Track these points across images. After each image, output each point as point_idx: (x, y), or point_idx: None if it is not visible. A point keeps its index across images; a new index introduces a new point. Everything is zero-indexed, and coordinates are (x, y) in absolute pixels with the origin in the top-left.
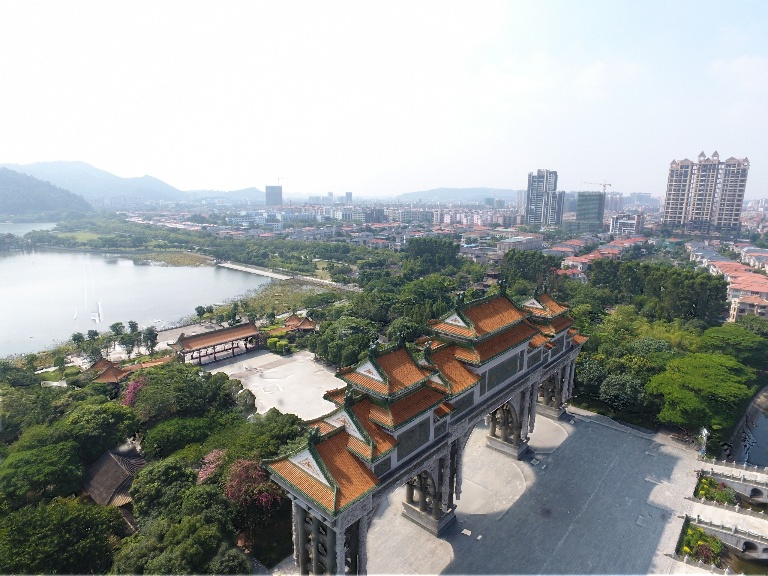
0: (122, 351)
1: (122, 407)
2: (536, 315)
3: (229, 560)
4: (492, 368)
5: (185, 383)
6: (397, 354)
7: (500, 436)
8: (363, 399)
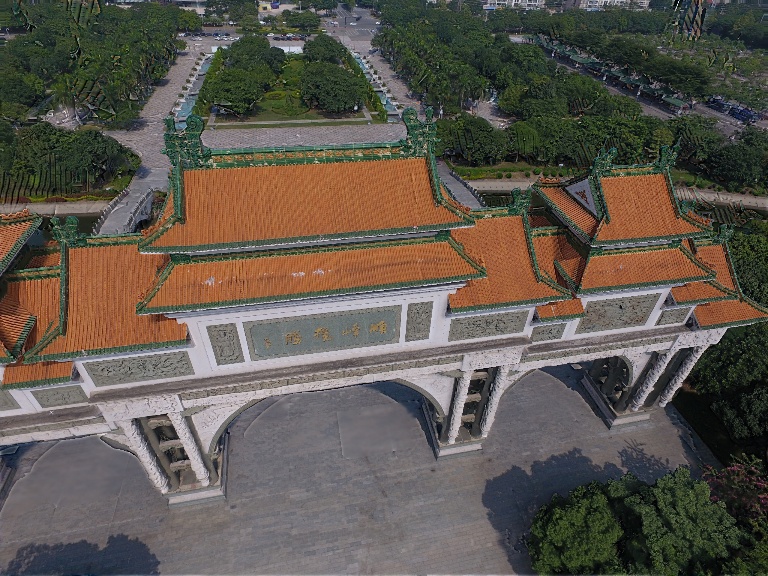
0: None
1: None
2: (22, 246)
3: (760, 396)
4: None
5: None
6: None
7: None
8: None
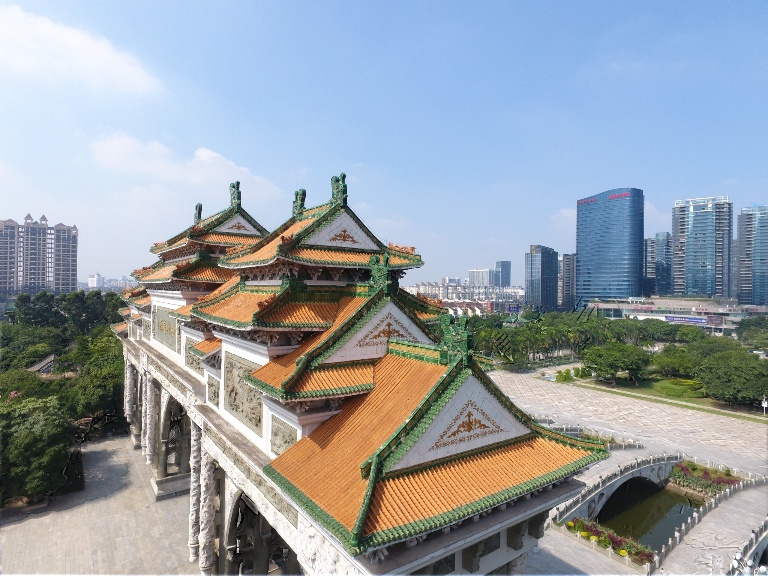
0: None
1: None
2: None
3: None
4: None
5: None
6: None
7: (174, 472)
8: None
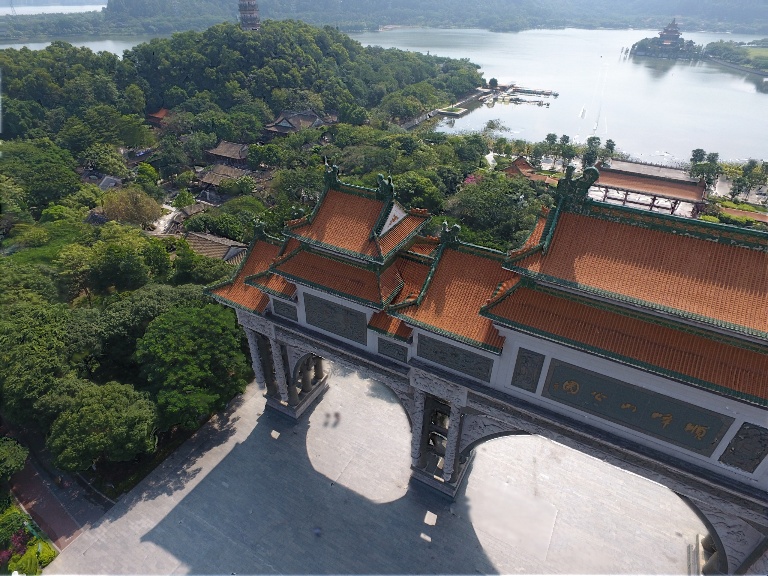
0: (561, 162)
1: (430, 187)
2: None
3: None
4: (572, 365)
5: (500, 197)
6: (369, 204)
7: None
8: None
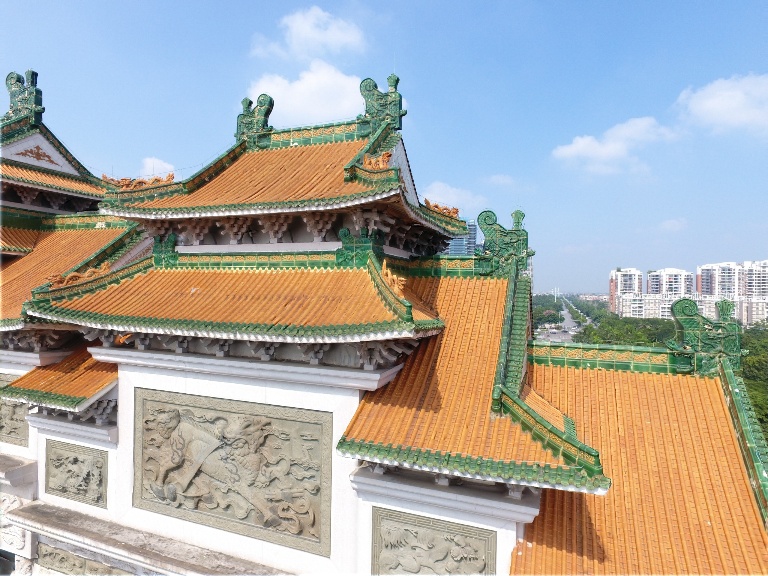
0: None
1: None
2: None
3: None
4: None
5: None
6: None
7: None
8: (431, 272)
